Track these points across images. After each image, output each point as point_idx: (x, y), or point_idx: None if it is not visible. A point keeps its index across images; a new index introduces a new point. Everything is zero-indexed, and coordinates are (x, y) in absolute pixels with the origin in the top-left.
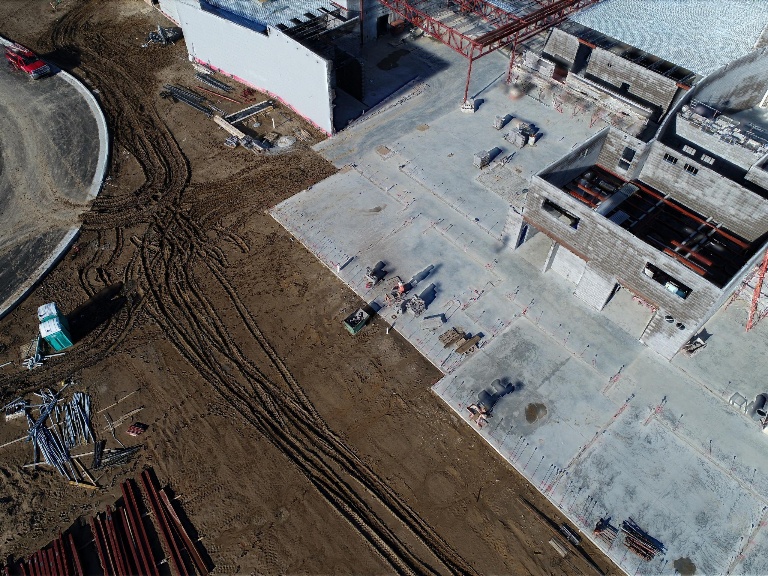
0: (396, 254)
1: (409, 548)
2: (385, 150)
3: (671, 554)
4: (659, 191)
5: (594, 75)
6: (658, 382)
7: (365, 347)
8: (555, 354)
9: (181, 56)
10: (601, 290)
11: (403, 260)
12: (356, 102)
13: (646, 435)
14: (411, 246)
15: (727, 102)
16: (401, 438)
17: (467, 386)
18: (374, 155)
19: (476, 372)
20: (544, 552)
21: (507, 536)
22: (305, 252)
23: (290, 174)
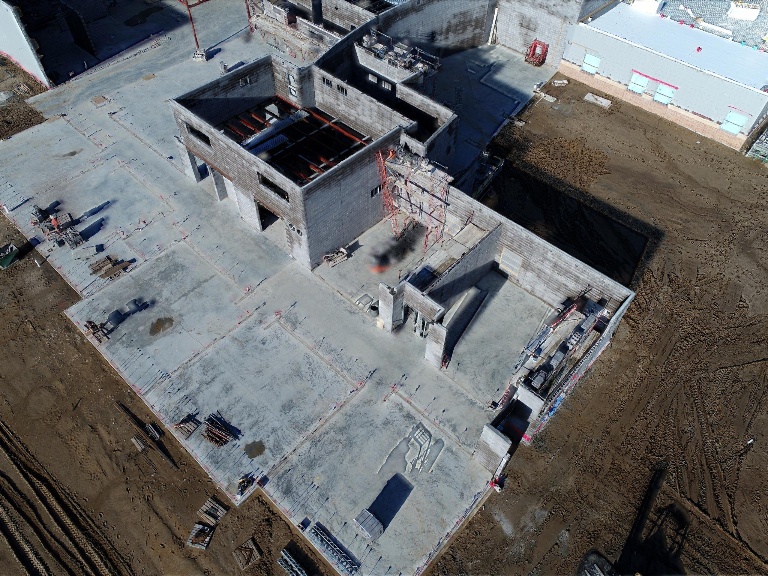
0: (75, 193)
1: None
2: (101, 99)
3: (245, 439)
4: (332, 117)
5: (329, 20)
6: (293, 290)
7: (11, 280)
8: (201, 273)
9: None
10: (251, 209)
11: (80, 198)
12: (89, 57)
13: (263, 337)
14: (93, 185)
15: (446, 39)
16: (17, 360)
17: (101, 307)
18: (88, 104)
19: (115, 294)
20: (123, 449)
21: (91, 438)
22: None
23: None
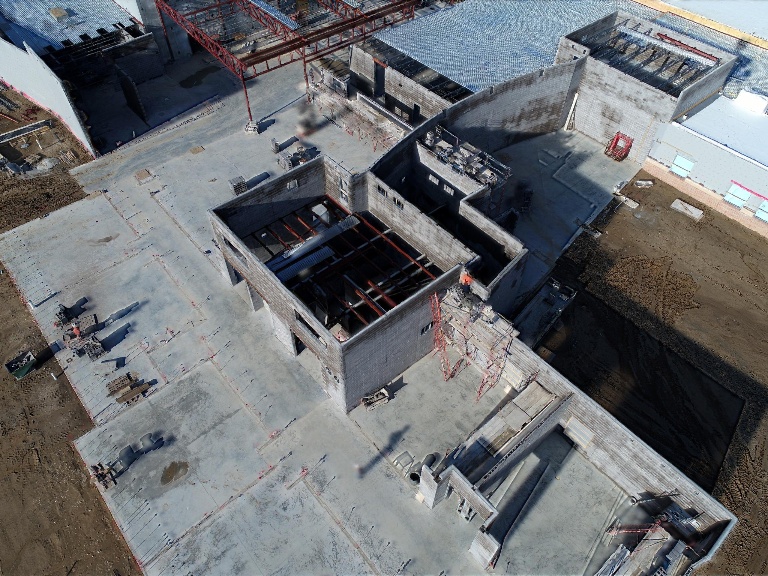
0: (104, 289)
1: None
2: (146, 174)
3: None
4: (385, 224)
5: (392, 95)
6: (324, 438)
7: (25, 394)
8: (225, 405)
9: None
10: (286, 334)
11: (109, 296)
12: (139, 122)
13: (285, 500)
14: (124, 280)
15: (518, 126)
16: (16, 500)
17: (112, 441)
18: (131, 180)
19: (130, 425)
20: None
21: None
22: (9, 286)
23: (34, 200)
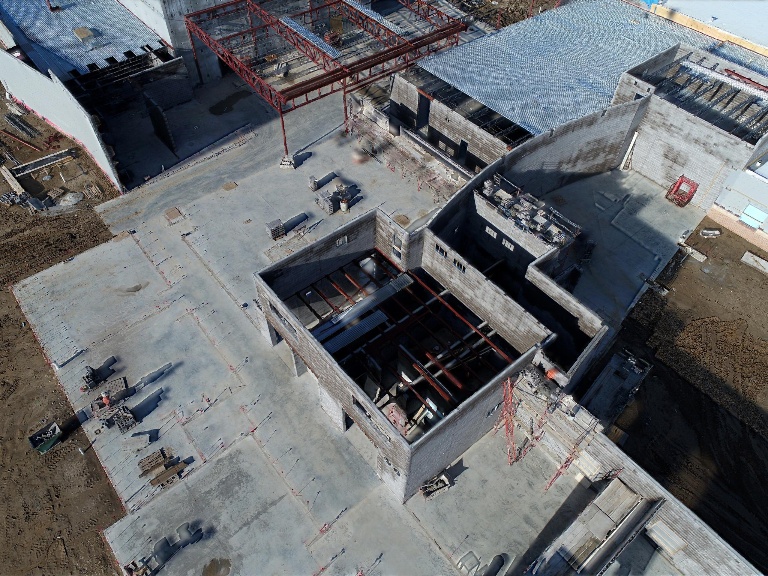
0: (134, 347)
1: None
2: (176, 213)
3: None
4: (440, 284)
5: (436, 129)
6: (380, 533)
7: (49, 471)
8: (269, 489)
9: (0, 93)
10: (336, 411)
11: (139, 356)
12: (168, 153)
13: None
14: (156, 337)
15: (573, 166)
16: None
17: (146, 531)
18: (161, 219)
19: (165, 512)
20: None
21: None
22: (32, 341)
23: (57, 240)
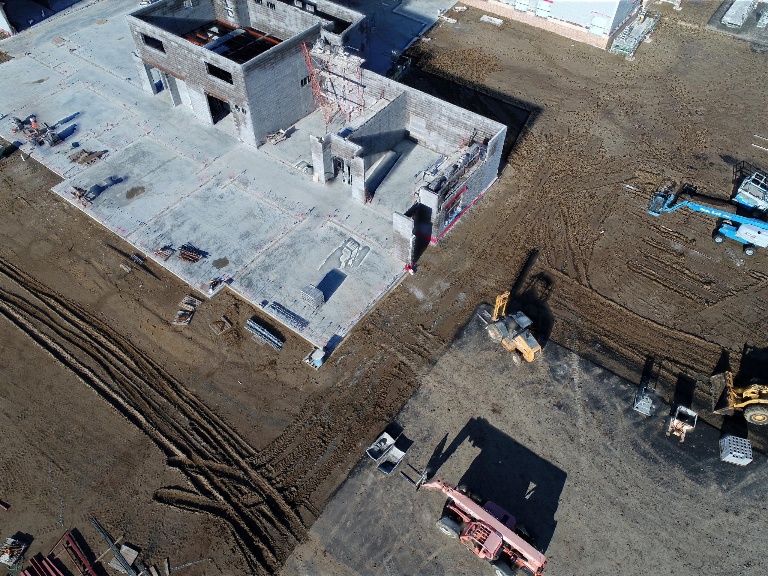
0: (48, 109)
1: (2, 287)
2: (61, 40)
3: (213, 257)
4: (265, 33)
5: None
6: (243, 162)
7: (1, 172)
8: (165, 156)
9: None
10: (202, 104)
11: (53, 112)
12: (44, 9)
13: (221, 194)
14: (63, 102)
15: None
16: (16, 224)
17: (82, 184)
18: (49, 45)
19: (93, 174)
20: (114, 272)
21: (87, 268)
22: None
23: None
